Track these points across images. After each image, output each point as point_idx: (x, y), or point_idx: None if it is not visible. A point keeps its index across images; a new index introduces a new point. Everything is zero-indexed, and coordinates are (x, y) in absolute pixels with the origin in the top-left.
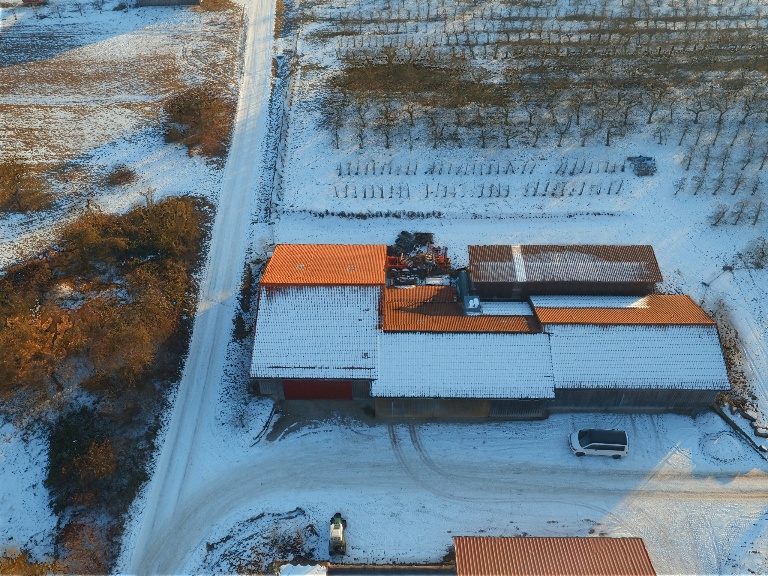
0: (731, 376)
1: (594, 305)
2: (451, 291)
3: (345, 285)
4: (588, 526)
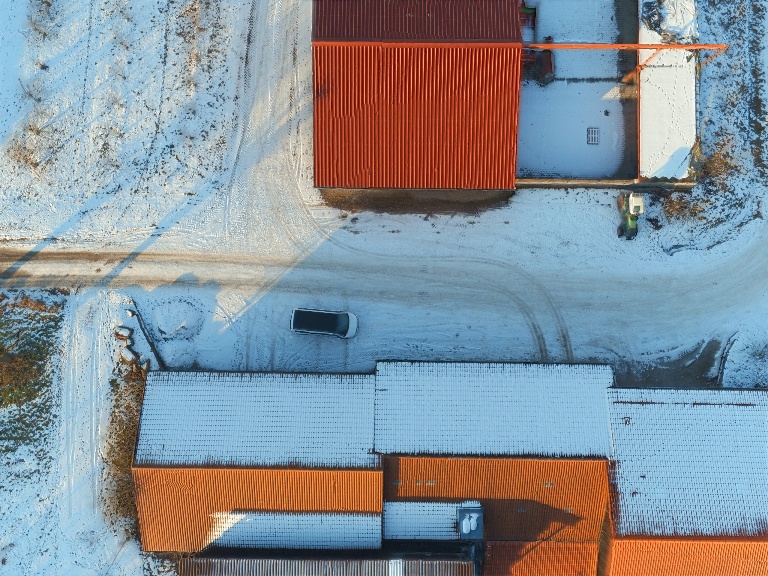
0: (129, 417)
1: (293, 520)
2: (493, 572)
3: (675, 538)
4: (357, 226)
